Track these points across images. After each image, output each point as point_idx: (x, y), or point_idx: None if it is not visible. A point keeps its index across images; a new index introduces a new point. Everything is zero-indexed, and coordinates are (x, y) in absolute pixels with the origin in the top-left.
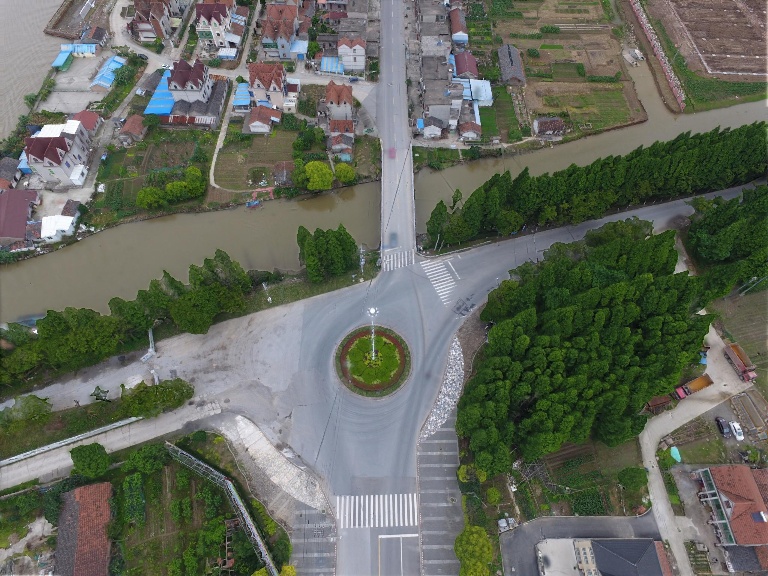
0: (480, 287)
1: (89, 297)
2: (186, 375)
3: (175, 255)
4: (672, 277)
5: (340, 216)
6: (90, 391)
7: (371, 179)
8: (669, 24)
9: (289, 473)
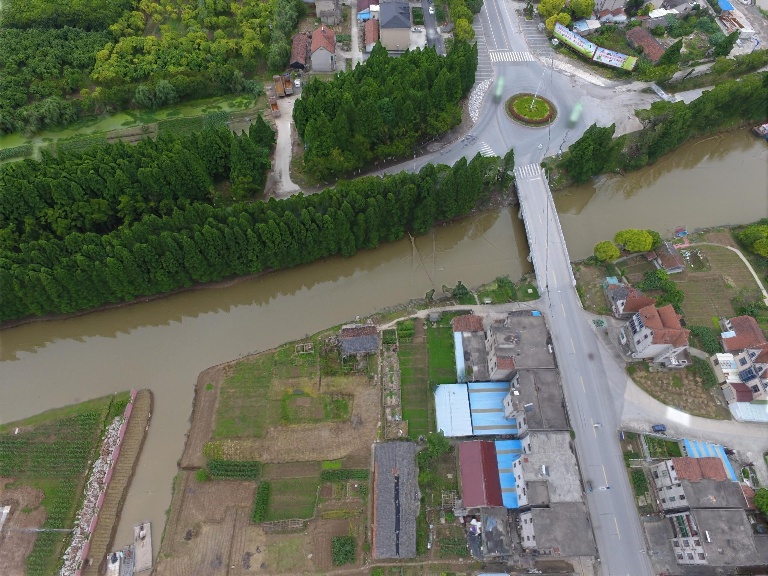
0: (457, 153)
1: (760, 181)
2: (648, 102)
3: (719, 207)
4: (330, 95)
5: (589, 249)
6: (700, 94)
7: (574, 263)
8: None
9: (563, 67)
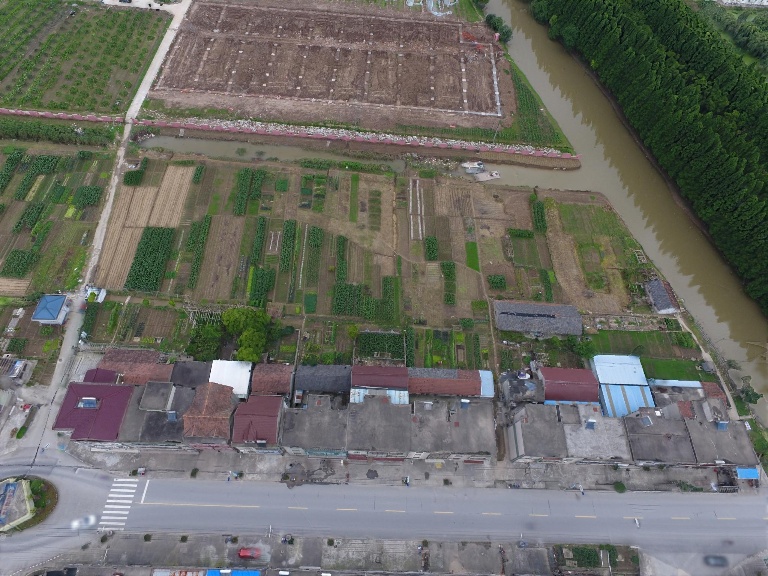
0: None
1: None
2: None
3: None
4: None
5: None
6: None
7: None
8: (405, 119)
9: None
